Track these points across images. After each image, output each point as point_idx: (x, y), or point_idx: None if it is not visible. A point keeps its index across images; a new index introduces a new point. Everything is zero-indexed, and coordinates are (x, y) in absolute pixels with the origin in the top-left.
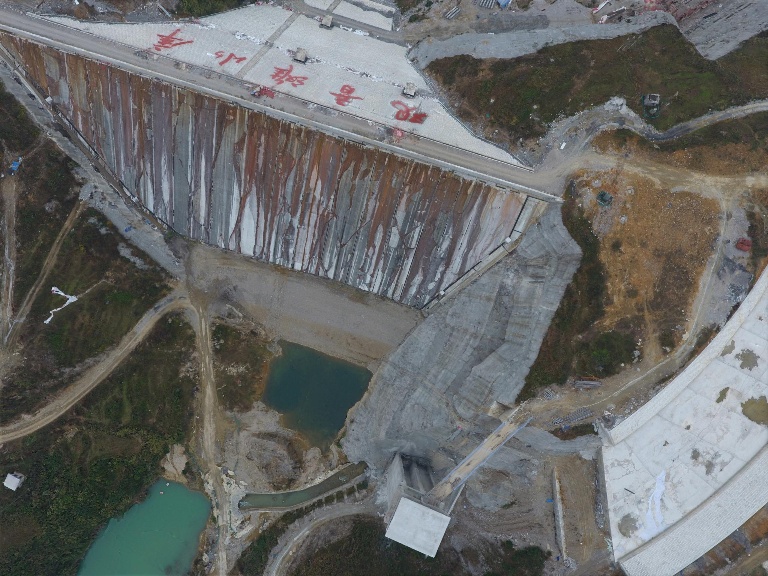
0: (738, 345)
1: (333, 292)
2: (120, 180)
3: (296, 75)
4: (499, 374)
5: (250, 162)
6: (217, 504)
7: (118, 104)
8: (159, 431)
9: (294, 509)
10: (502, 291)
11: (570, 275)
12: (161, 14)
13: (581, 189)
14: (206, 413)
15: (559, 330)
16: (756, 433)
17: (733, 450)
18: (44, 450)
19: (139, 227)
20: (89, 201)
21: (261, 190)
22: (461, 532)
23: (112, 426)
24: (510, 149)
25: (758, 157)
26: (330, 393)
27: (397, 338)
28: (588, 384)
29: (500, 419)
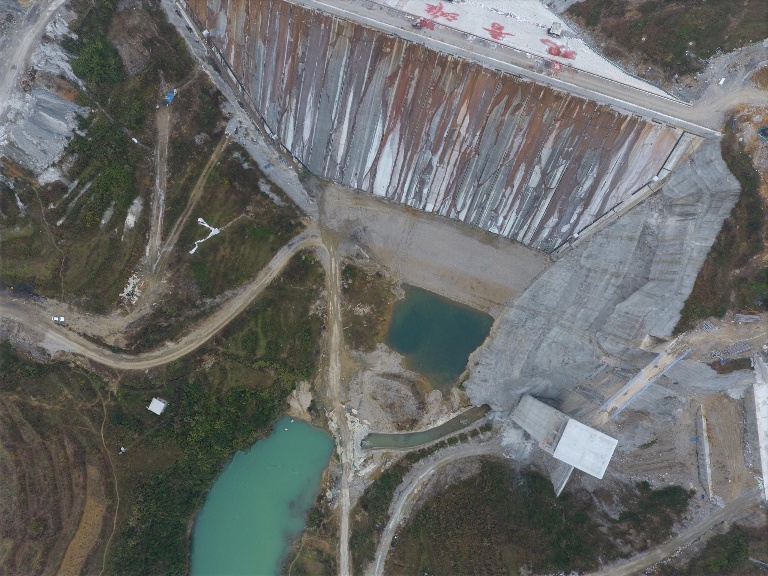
0: None
1: (463, 234)
2: (262, 117)
3: (448, 11)
4: (650, 309)
5: (399, 97)
6: (341, 442)
7: (274, 37)
8: (289, 366)
9: (416, 449)
10: (646, 230)
11: (727, 210)
12: None
13: (742, 124)
14: (332, 352)
15: (716, 264)
16: None
17: None
18: (185, 378)
19: (277, 165)
20: (234, 136)
21: (405, 127)
22: None
23: (248, 358)
24: (664, 86)
25: None
26: (451, 337)
27: (524, 282)
28: (748, 318)
29: (655, 351)
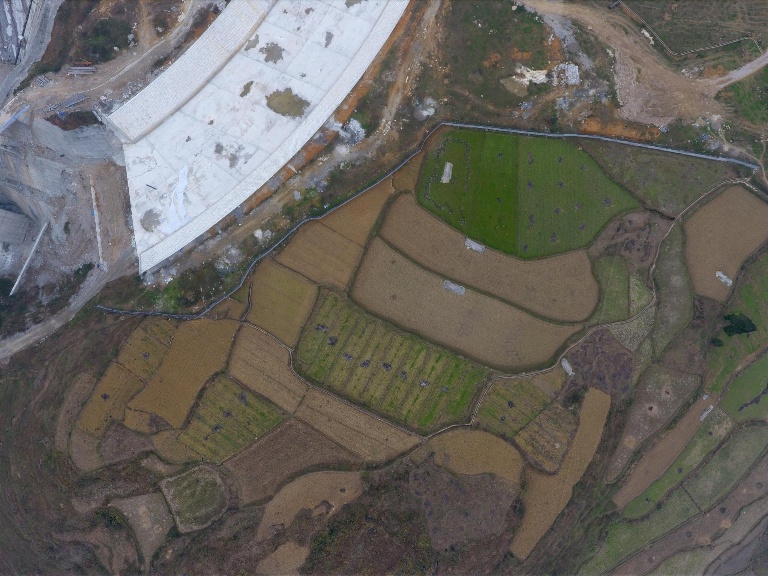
0: (262, 39)
1: None
2: None
3: None
4: (17, 79)
5: None
6: None
7: None
8: None
9: None
10: (47, 13)
11: None
12: None
13: None
14: None
15: (59, 22)
16: (281, 125)
17: (257, 142)
18: None
19: None
20: None
21: None
22: (47, 271)
23: None
24: None
25: None
26: None
27: None
28: (81, 69)
29: None
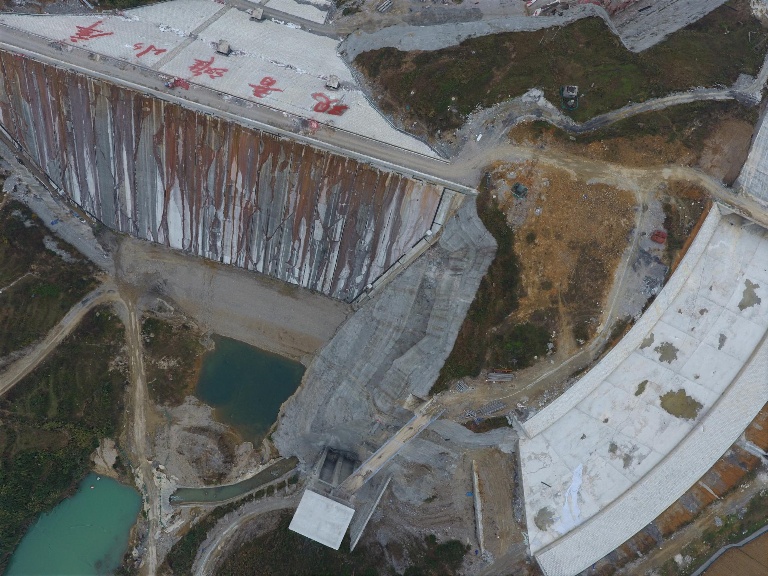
0: (657, 338)
1: (262, 286)
2: (45, 173)
3: (216, 67)
4: (416, 367)
5: (170, 154)
6: (147, 498)
7: (36, 96)
8: (87, 425)
9: (225, 503)
10: (424, 284)
11: (486, 267)
12: (83, 6)
13: (496, 181)
14: (136, 407)
15: (474, 322)
16: (675, 426)
17: (651, 443)
18: None
19: (66, 220)
20: (13, 194)
21: (184, 183)
22: (387, 526)
23: (37, 420)
24: (429, 141)
25: (675, 149)
26: (264, 387)
27: (328, 332)
28: (501, 376)
29: (414, 412)
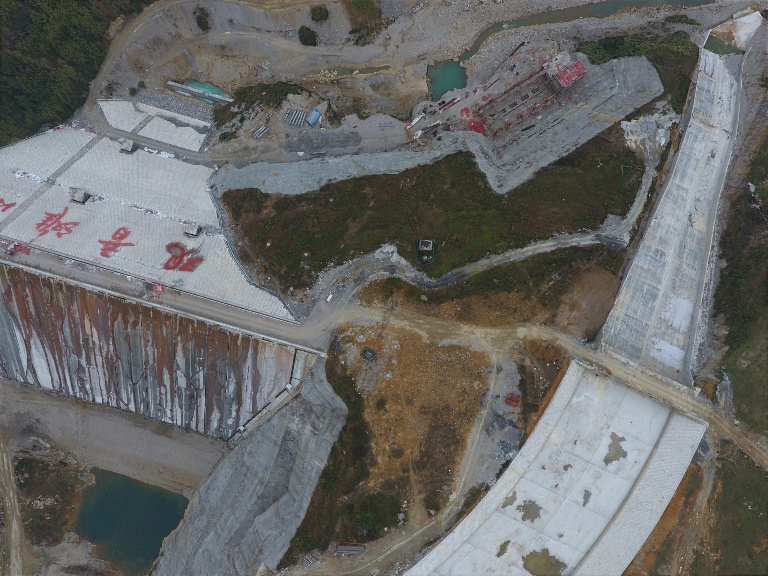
0: (520, 496)
1: (136, 425)
2: None
3: (67, 221)
4: (270, 533)
5: (23, 310)
6: None
7: None
8: None
9: None
10: (287, 436)
11: (337, 432)
12: None
13: (345, 345)
14: (12, 548)
15: (324, 491)
16: None
17: None
18: None
19: None
20: None
21: (41, 334)
22: None
23: None
24: (282, 297)
25: (531, 306)
26: (146, 521)
27: (206, 469)
28: (350, 550)
29: None
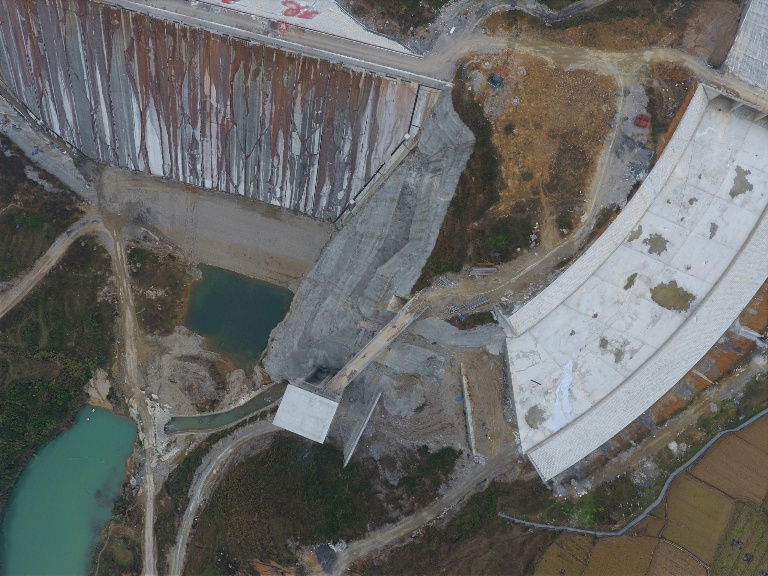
0: (645, 230)
1: (245, 209)
2: (23, 102)
3: None
4: (398, 269)
5: (143, 71)
6: (142, 428)
7: (6, 17)
8: (79, 355)
9: (219, 430)
10: (405, 190)
11: (464, 162)
12: None
13: (471, 72)
14: (127, 338)
15: (454, 218)
16: (667, 319)
17: (643, 337)
18: None
19: (46, 151)
20: None
21: (159, 101)
22: (380, 441)
23: (28, 349)
24: (402, 40)
25: (656, 30)
26: (253, 315)
27: (313, 254)
28: (484, 270)
29: (397, 312)
